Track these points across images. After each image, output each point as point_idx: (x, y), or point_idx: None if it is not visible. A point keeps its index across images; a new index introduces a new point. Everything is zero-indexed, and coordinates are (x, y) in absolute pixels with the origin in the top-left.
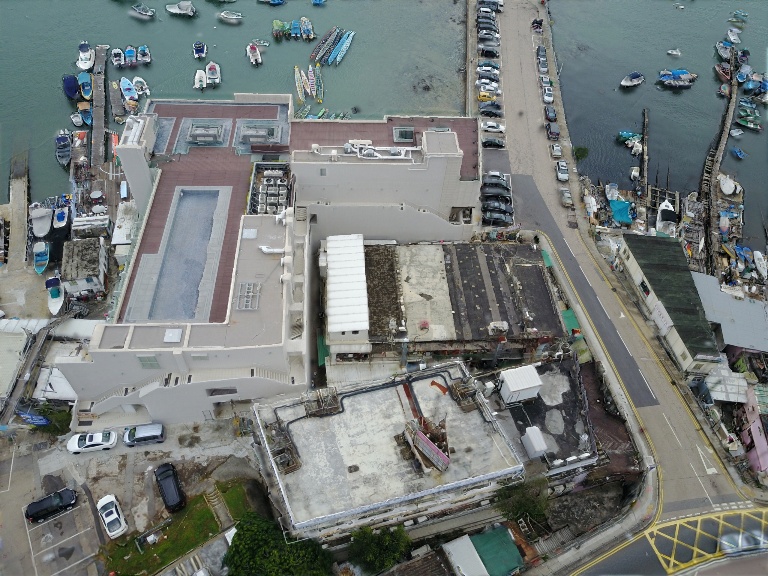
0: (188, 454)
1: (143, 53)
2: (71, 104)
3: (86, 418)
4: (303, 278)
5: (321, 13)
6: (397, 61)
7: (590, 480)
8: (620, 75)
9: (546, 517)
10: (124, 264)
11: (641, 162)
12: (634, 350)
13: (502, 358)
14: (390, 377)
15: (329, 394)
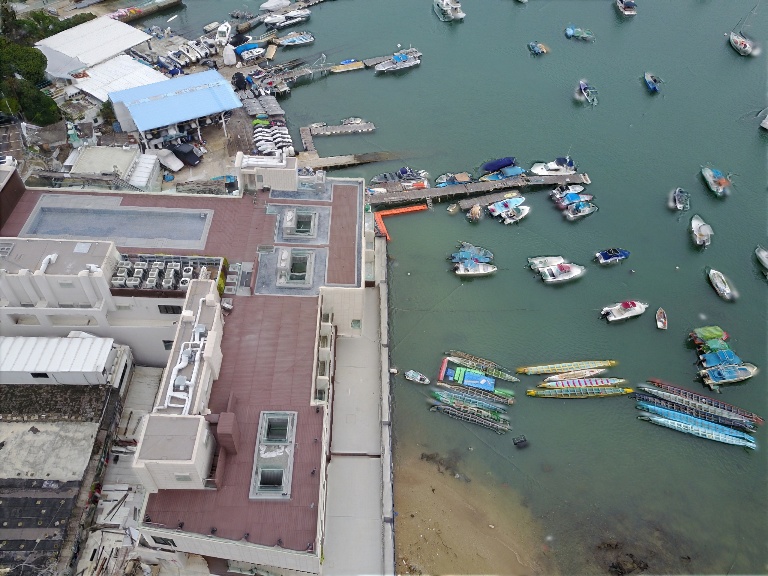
0: None
1: (578, 207)
2: (465, 169)
3: None
4: None
5: None
6: (697, 521)
7: None
8: None
9: None
10: None
11: None
12: None
13: None
14: None
15: None
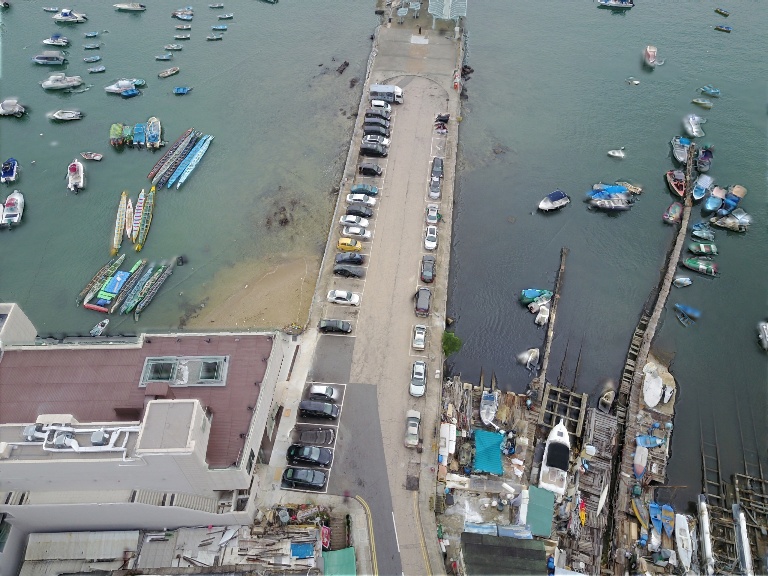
0: None
1: None
2: None
3: None
4: None
5: (182, 107)
6: (257, 178)
7: None
8: (540, 193)
9: None
10: None
11: (545, 338)
12: None
13: None
14: None
15: None
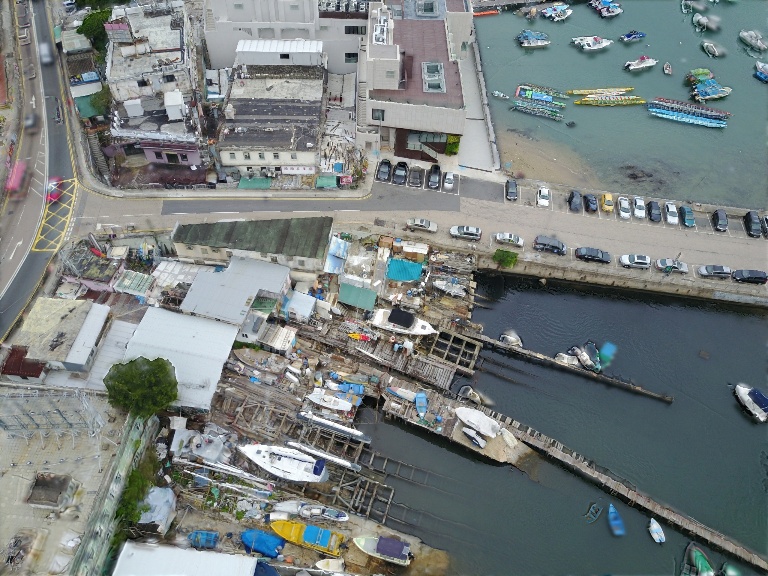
0: None
1: (608, 9)
2: None
3: None
4: None
5: (763, 108)
6: (685, 159)
7: None
8: (767, 391)
9: (110, 145)
10: None
11: None
12: (216, 216)
13: None
14: None
15: (179, 19)
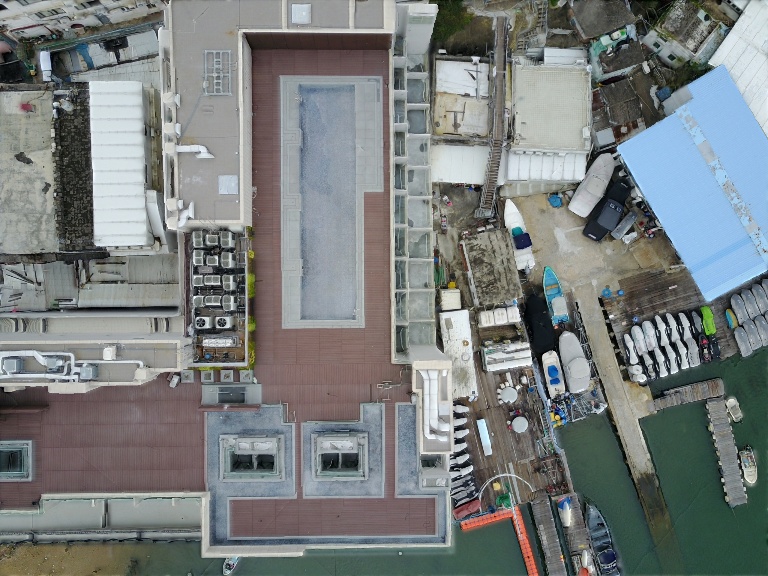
0: None
1: None
2: None
3: None
4: None
5: None
6: None
7: None
8: None
9: None
10: None
11: None
12: None
13: None
14: None
15: None
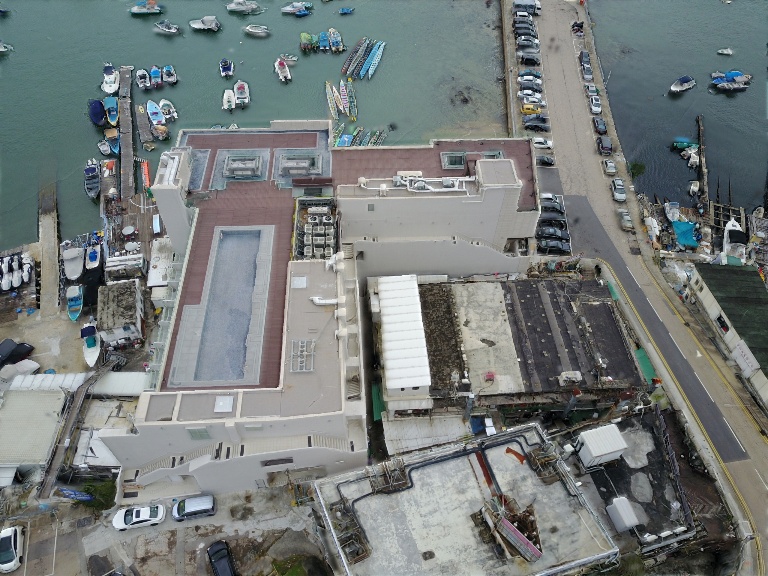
0: (242, 528)
1: (169, 73)
2: (98, 131)
3: (131, 489)
4: (357, 329)
5: (349, 23)
6: (432, 72)
7: (683, 552)
8: (669, 79)
9: None
10: (161, 307)
11: (699, 175)
12: (716, 395)
13: (573, 409)
14: (461, 444)
15: (397, 468)
